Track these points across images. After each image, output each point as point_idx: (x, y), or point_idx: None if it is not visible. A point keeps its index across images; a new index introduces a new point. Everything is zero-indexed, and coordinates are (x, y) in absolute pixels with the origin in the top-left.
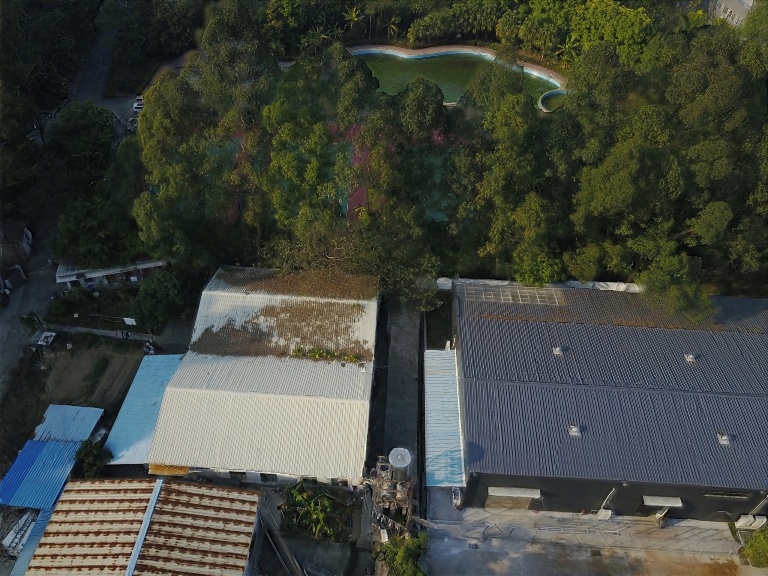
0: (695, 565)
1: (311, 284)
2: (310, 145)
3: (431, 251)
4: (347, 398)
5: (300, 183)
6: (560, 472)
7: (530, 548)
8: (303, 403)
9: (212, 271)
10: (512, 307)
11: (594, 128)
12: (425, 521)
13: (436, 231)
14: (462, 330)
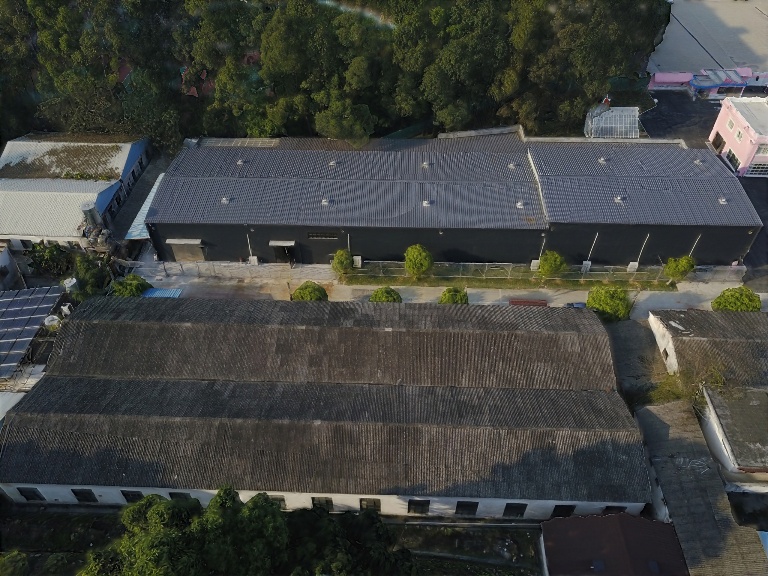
0: None
1: (91, 138)
2: (60, 24)
3: (175, 109)
4: (83, 192)
5: (59, 53)
6: (204, 221)
7: (197, 280)
8: (52, 196)
9: (23, 134)
10: (235, 148)
11: None
12: (121, 260)
13: (193, 102)
14: (180, 154)
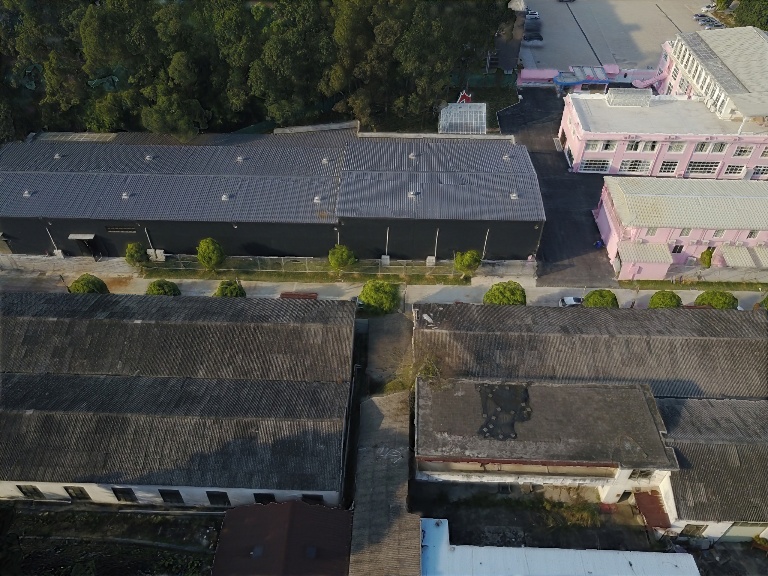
0: (104, 278)
1: None
2: None
3: (8, 103)
4: None
5: None
6: (0, 214)
7: None
8: None
9: None
10: (68, 142)
11: (101, 5)
12: None
13: (36, 97)
14: (2, 148)
